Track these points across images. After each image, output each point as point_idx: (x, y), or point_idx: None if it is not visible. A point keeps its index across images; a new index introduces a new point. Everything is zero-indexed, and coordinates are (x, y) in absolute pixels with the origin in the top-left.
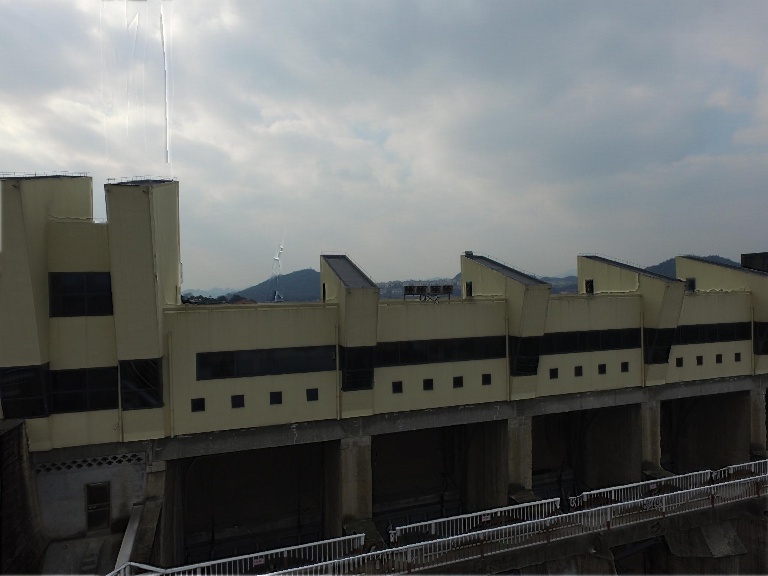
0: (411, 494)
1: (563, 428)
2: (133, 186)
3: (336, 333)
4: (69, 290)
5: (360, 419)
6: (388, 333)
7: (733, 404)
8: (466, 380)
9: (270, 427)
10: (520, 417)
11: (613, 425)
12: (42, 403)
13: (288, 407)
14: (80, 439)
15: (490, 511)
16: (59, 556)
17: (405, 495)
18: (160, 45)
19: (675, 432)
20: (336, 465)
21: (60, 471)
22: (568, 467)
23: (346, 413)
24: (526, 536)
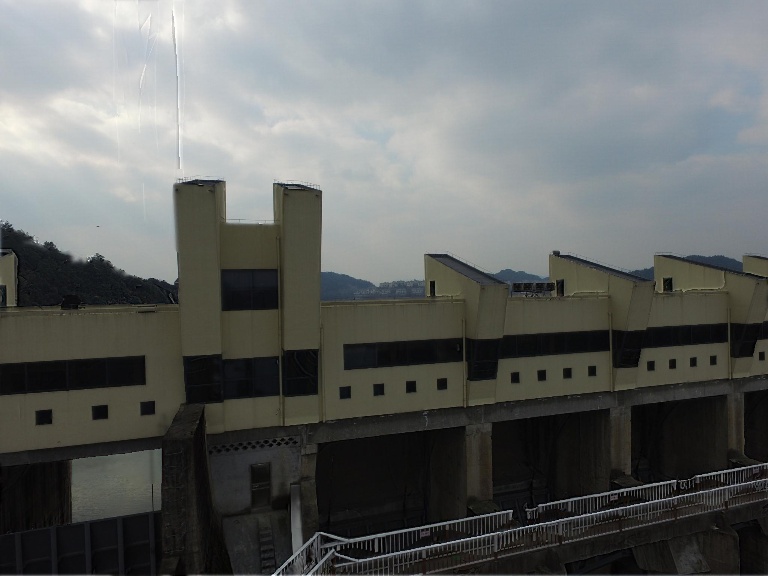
0: (501, 481)
1: (636, 420)
2: (308, 191)
3: (463, 327)
4: (237, 286)
5: (482, 407)
6: (507, 327)
7: None
8: (574, 371)
9: (405, 414)
10: (621, 407)
11: (695, 416)
12: (219, 389)
13: (421, 395)
14: (247, 423)
15: (617, 491)
16: (235, 529)
17: (496, 482)
18: (172, 46)
19: None
20: (456, 451)
21: (229, 452)
22: (643, 457)
23: (472, 401)
24: (657, 513)
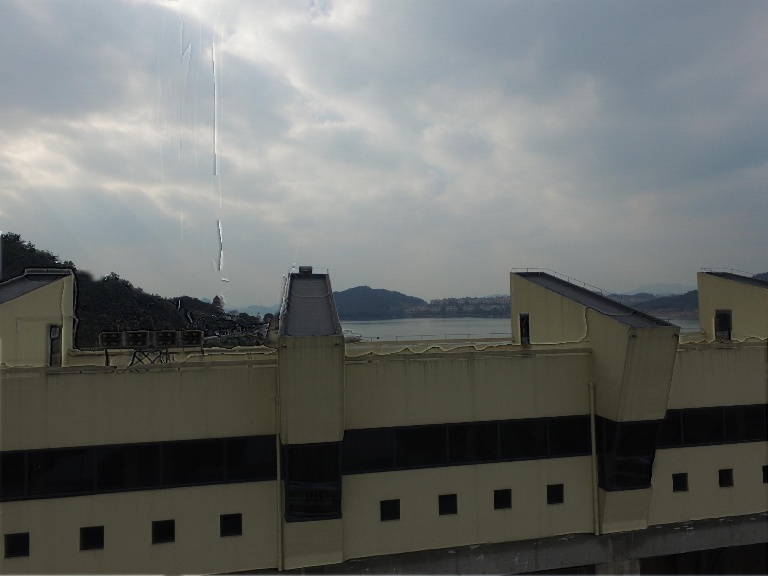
0: None
1: None
2: None
3: None
4: None
5: None
6: (0, 433)
7: None
8: (183, 527)
9: None
10: None
11: None
12: None
13: None
14: None
15: None
16: None
17: None
18: None
19: (705, 573)
20: None
21: None
22: None
23: None
24: None
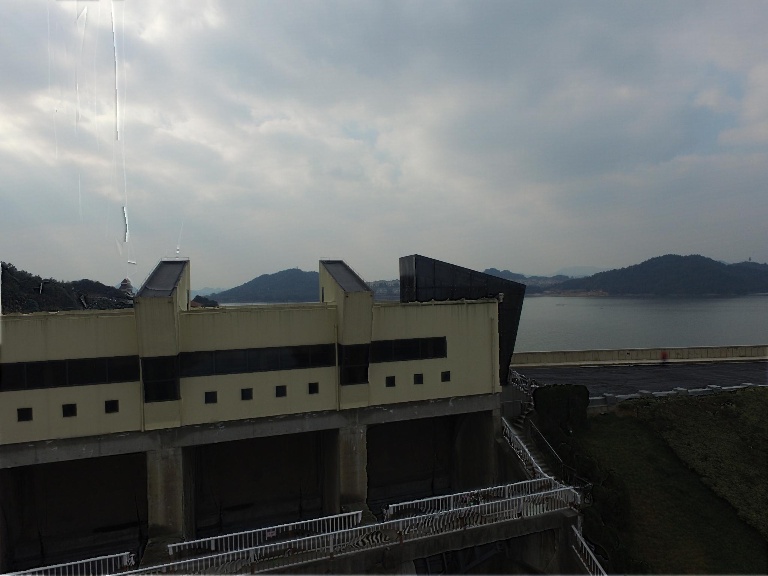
0: None
1: None
2: None
3: None
4: None
5: None
6: None
7: (335, 444)
8: None
9: None
10: None
11: None
12: None
13: None
14: None
15: None
16: None
17: None
18: None
19: (322, 472)
20: None
21: None
22: None
23: None
24: None
